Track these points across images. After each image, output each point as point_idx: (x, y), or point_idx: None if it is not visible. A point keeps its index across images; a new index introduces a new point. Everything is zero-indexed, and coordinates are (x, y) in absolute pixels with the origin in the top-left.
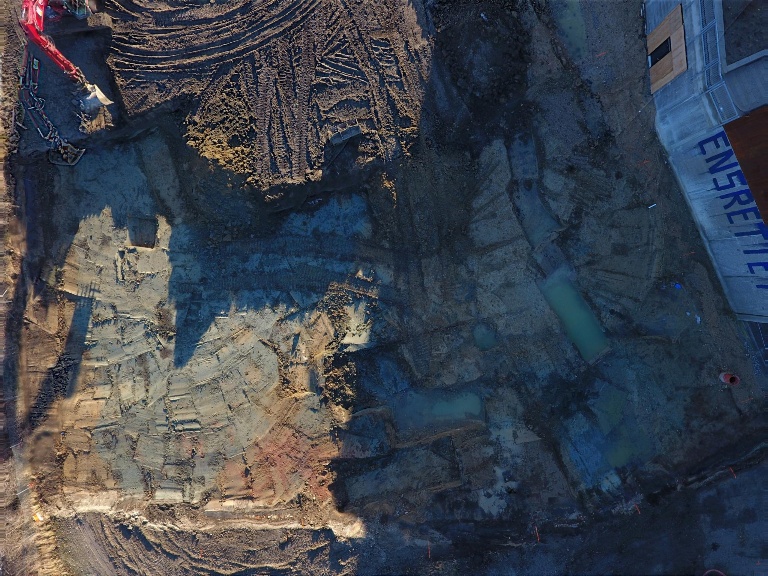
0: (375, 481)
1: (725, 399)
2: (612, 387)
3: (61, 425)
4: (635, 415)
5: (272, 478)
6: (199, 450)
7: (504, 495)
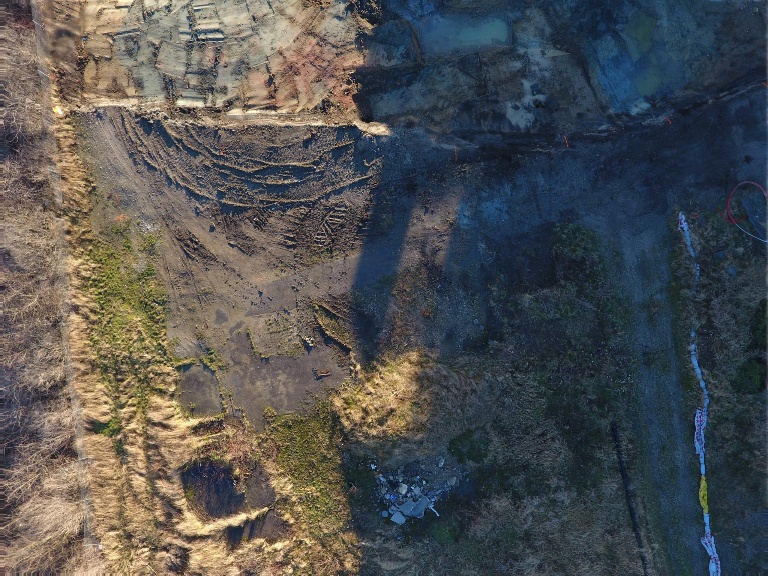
0: (400, 100)
1: (756, 23)
2: (641, 13)
3: (83, 30)
4: (664, 41)
5: (296, 87)
6: (222, 60)
7: (532, 108)
